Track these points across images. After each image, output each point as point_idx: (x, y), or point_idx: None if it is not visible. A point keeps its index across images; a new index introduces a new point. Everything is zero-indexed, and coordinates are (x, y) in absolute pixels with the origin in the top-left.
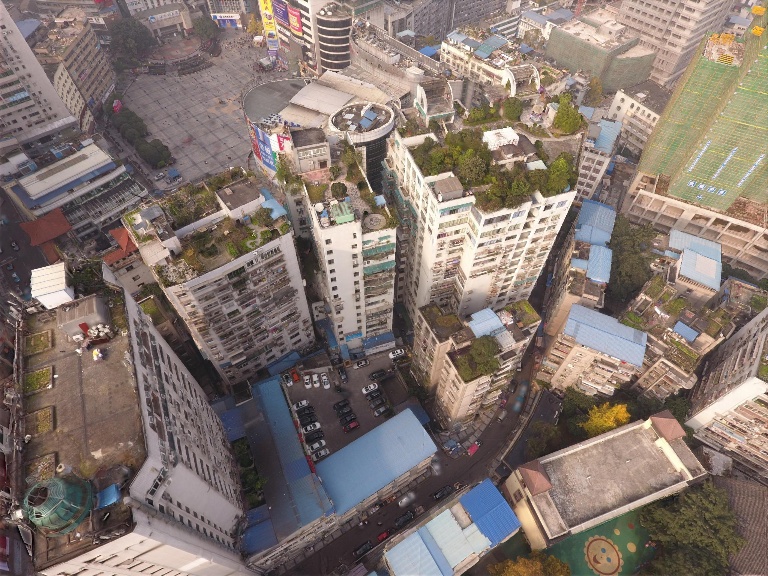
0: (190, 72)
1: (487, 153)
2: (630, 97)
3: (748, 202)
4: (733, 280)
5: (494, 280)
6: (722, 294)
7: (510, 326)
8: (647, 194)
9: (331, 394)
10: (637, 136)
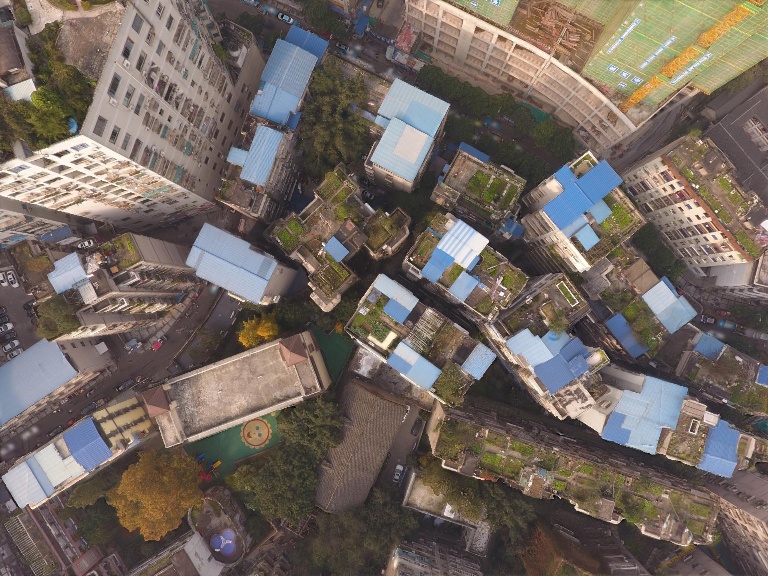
0: None
1: None
2: None
3: (553, 3)
4: (461, 151)
5: (102, 202)
6: None
7: (92, 278)
8: None
9: (21, 292)
10: None
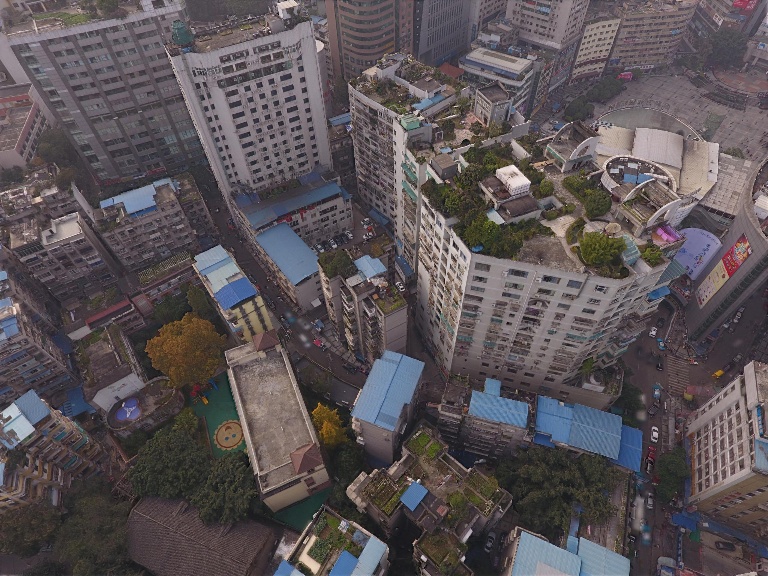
0: (715, 100)
1: (485, 171)
2: None
3: None
4: None
5: None
6: None
7: None
8: None
9: None
10: None
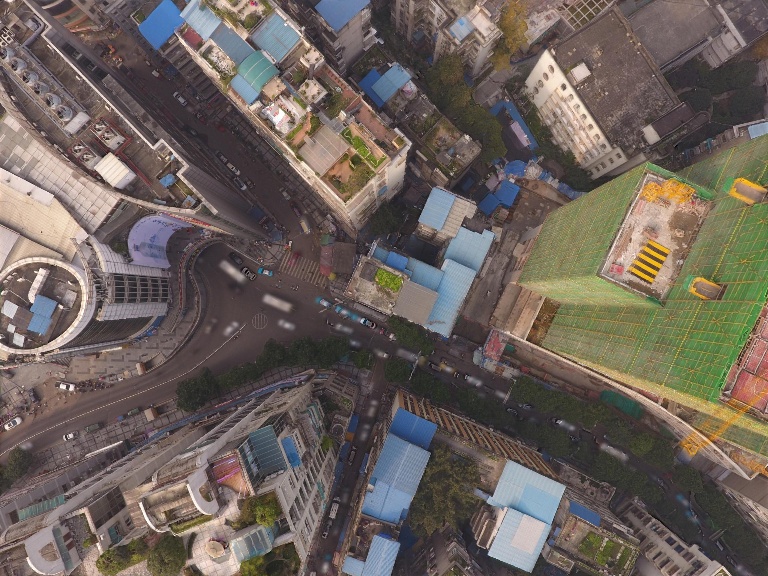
0: None
1: None
2: (562, 72)
3: None
4: None
5: None
6: (557, 519)
7: None
8: (516, 337)
9: None
10: (567, 130)
